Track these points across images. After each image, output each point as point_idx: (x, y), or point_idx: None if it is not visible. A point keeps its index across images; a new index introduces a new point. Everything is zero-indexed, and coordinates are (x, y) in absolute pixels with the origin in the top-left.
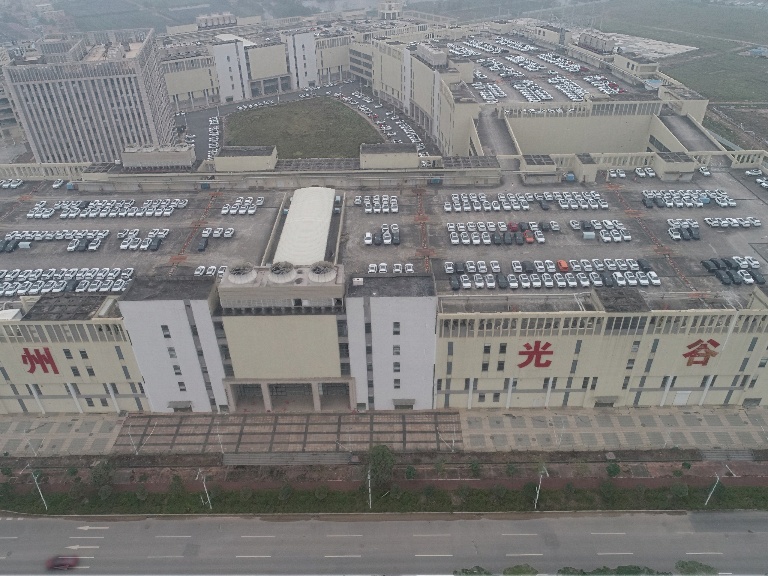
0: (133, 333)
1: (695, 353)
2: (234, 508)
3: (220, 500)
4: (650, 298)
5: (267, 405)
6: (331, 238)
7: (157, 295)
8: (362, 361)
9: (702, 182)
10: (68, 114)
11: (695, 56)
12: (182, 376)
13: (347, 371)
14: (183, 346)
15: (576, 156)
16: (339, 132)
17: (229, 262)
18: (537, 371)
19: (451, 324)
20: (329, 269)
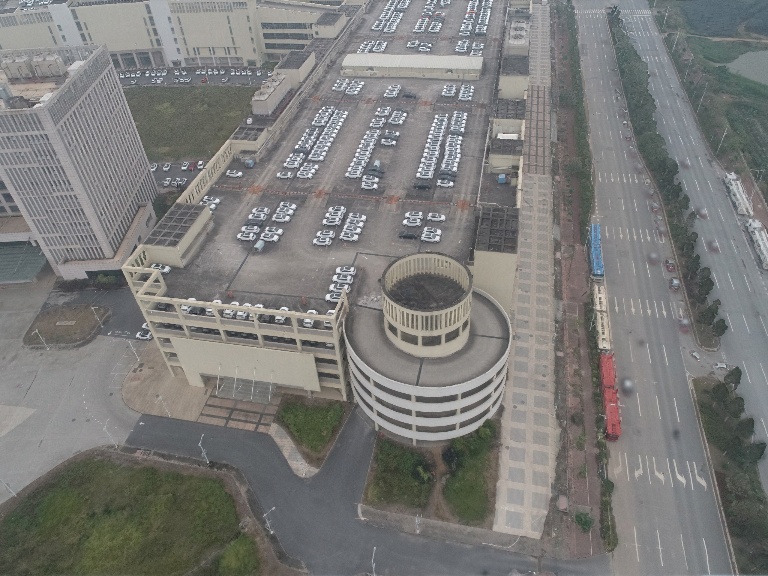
0: None
1: None
2: None
3: None
4: (502, 4)
5: None
6: None
7: (518, 71)
8: None
9: None
10: (94, 144)
11: None
12: None
13: None
14: None
15: None
16: None
17: (435, 89)
18: None
19: None
20: None
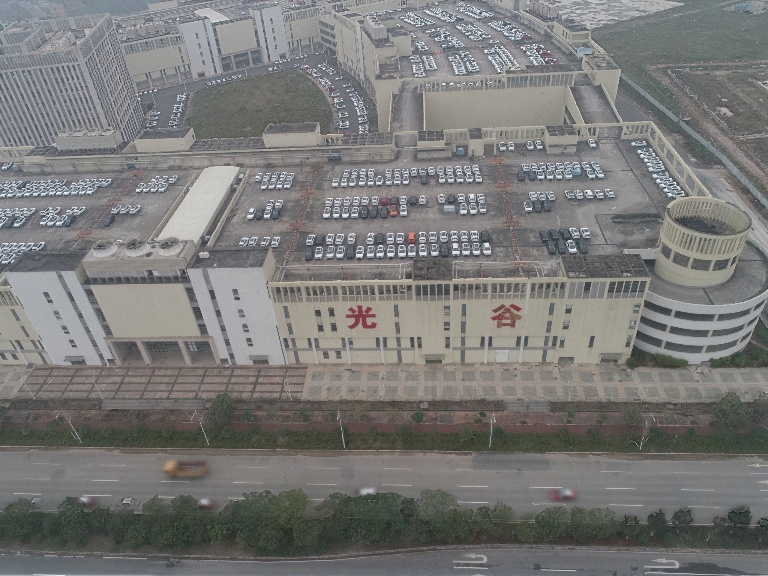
0: (22, 299)
1: (501, 316)
2: (99, 443)
3: (90, 436)
4: (475, 267)
5: (146, 360)
6: (221, 214)
7: (38, 267)
8: (215, 323)
9: (585, 154)
10: (22, 100)
11: (676, 13)
12: (71, 335)
13: (206, 331)
14: (65, 310)
15: (468, 131)
16: (292, 106)
17: (127, 236)
18: (366, 332)
19: (281, 291)
20: (174, 244)
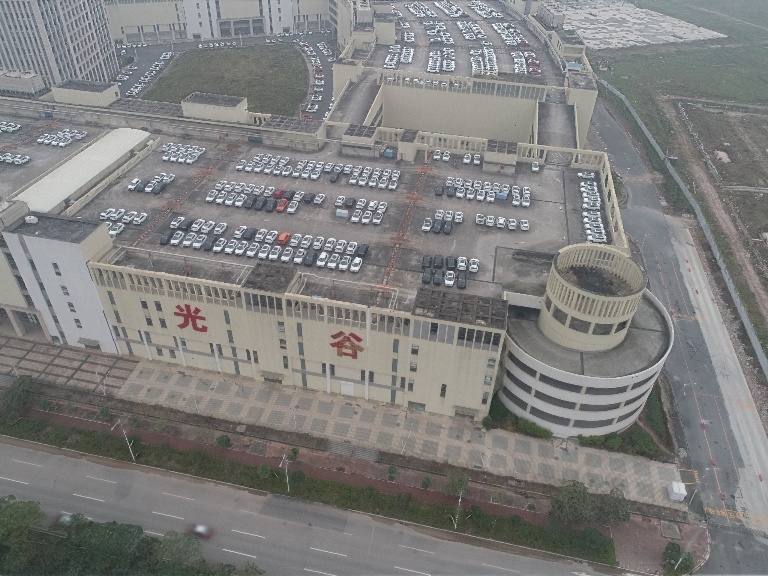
0: None
1: (341, 344)
2: None
3: None
4: None
5: None
6: None
7: None
8: (40, 296)
9: (523, 177)
10: None
11: (715, 44)
12: None
13: (33, 303)
14: None
15: (402, 132)
16: (270, 81)
17: None
18: (198, 335)
19: (103, 274)
20: None
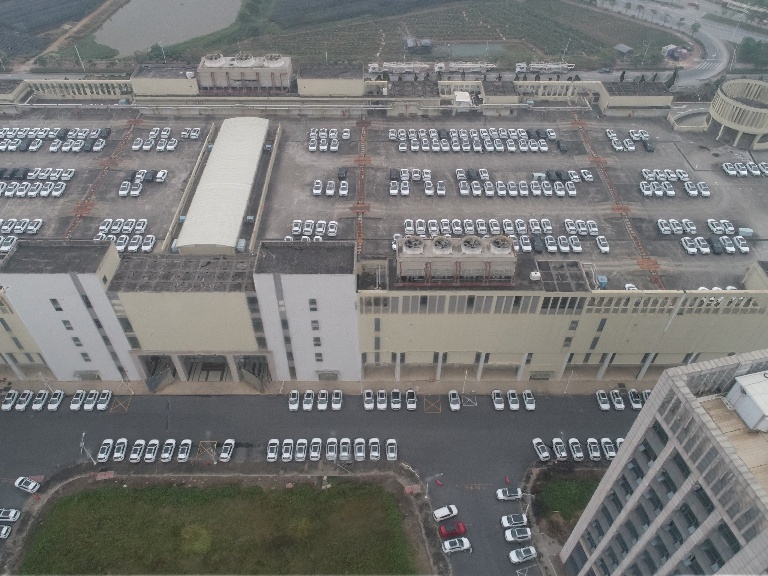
0: None
1: None
2: None
3: None
4: None
5: None
6: None
7: (340, 73)
8: None
9: None
10: None
11: None
12: None
13: None
14: None
15: None
16: None
17: (310, 159)
18: None
19: None
20: (209, 57)
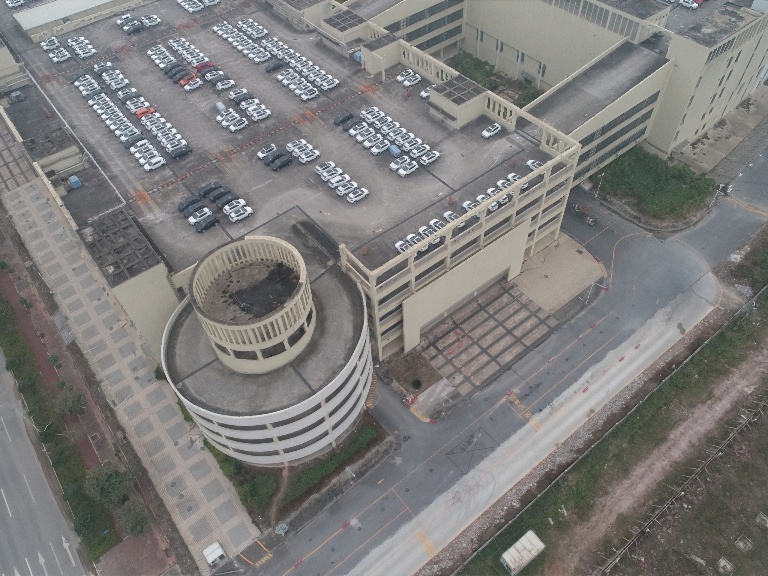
0: None
1: None
2: None
3: None
4: (119, 173)
5: None
6: None
7: None
8: None
9: (460, 138)
10: None
11: None
12: None
13: None
14: None
15: None
16: None
17: None
18: None
19: None
20: None
